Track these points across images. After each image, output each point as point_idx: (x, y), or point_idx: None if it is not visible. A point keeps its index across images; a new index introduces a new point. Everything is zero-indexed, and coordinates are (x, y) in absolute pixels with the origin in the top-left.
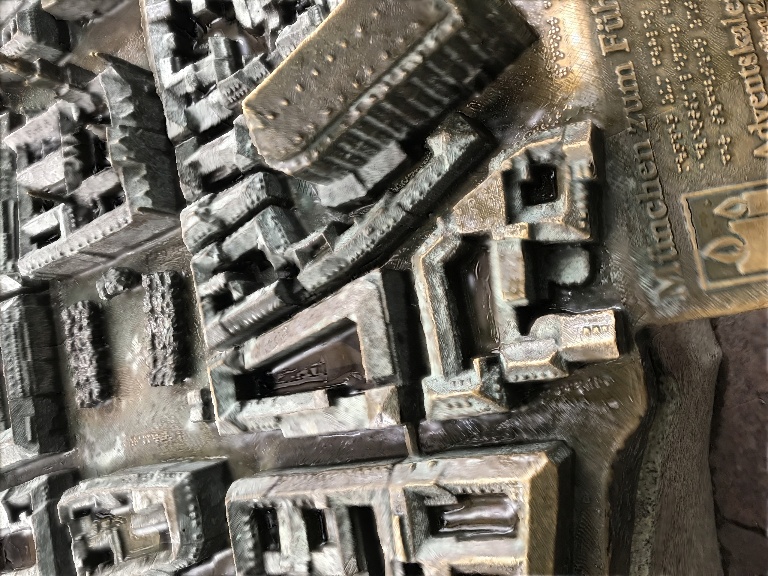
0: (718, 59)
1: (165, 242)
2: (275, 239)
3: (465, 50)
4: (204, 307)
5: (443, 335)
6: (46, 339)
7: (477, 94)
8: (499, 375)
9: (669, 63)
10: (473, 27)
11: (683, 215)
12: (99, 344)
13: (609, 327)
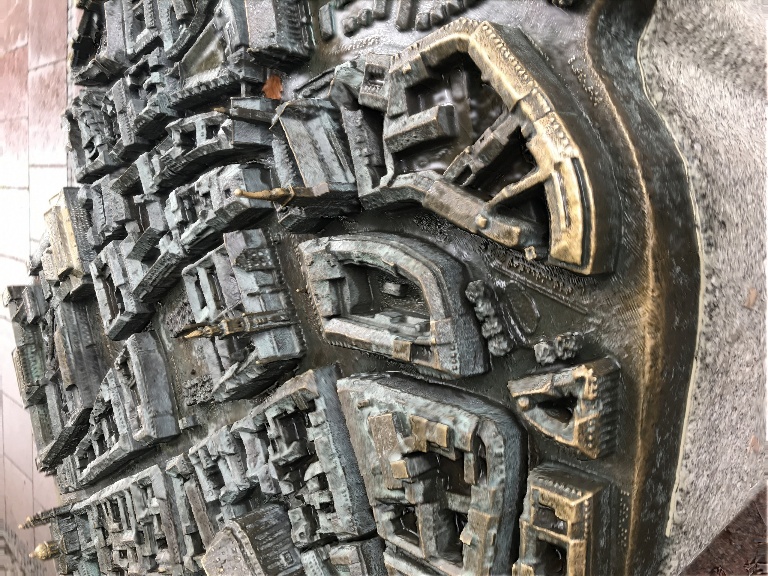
0: None
1: None
2: None
3: None
4: None
5: None
6: None
7: None
8: None
9: None
10: None
11: None
12: None
13: None
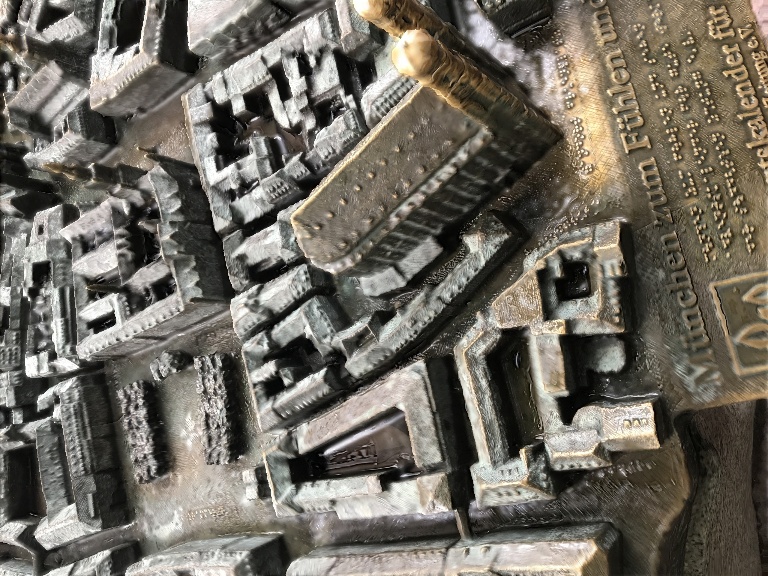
0: (737, 151)
1: (214, 324)
2: (322, 329)
3: (495, 157)
4: (257, 394)
5: (489, 425)
6: (103, 417)
7: (507, 189)
8: (545, 464)
9: (690, 157)
10: (502, 139)
11: (713, 303)
12: (154, 422)
13: (649, 420)
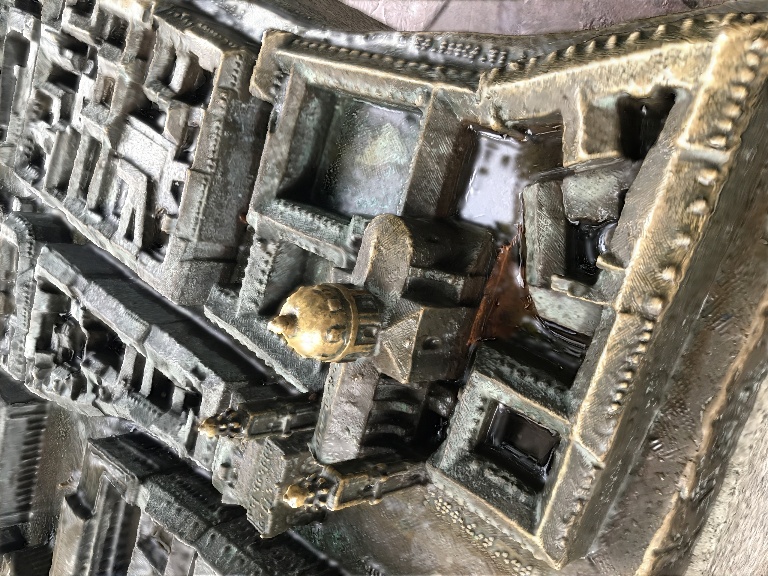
0: None
1: None
2: None
3: None
4: None
5: None
6: None
7: None
8: None
9: None
10: None
11: None
12: None
13: None
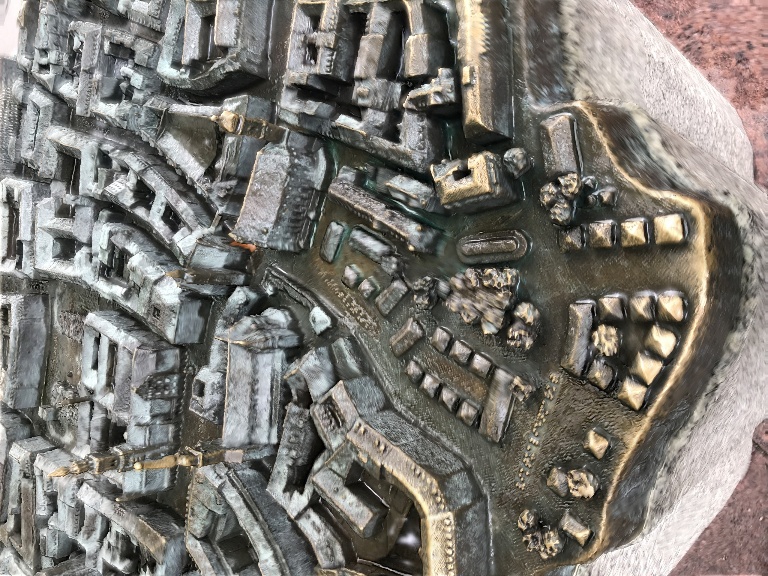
0: None
1: None
2: None
3: None
4: None
5: None
6: None
7: None
8: None
9: None
10: None
11: None
12: None
13: None
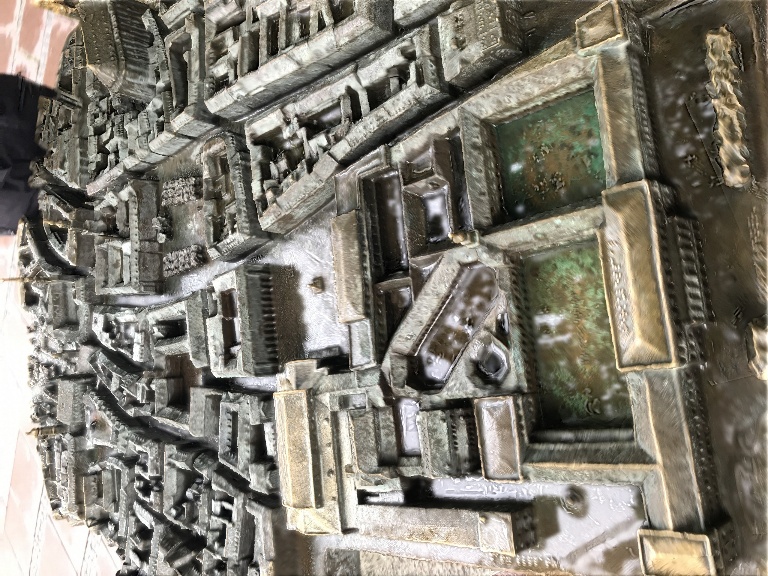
0: None
1: None
2: None
3: None
4: None
5: None
6: None
7: None
8: None
9: None
10: None
11: None
12: None
13: None
